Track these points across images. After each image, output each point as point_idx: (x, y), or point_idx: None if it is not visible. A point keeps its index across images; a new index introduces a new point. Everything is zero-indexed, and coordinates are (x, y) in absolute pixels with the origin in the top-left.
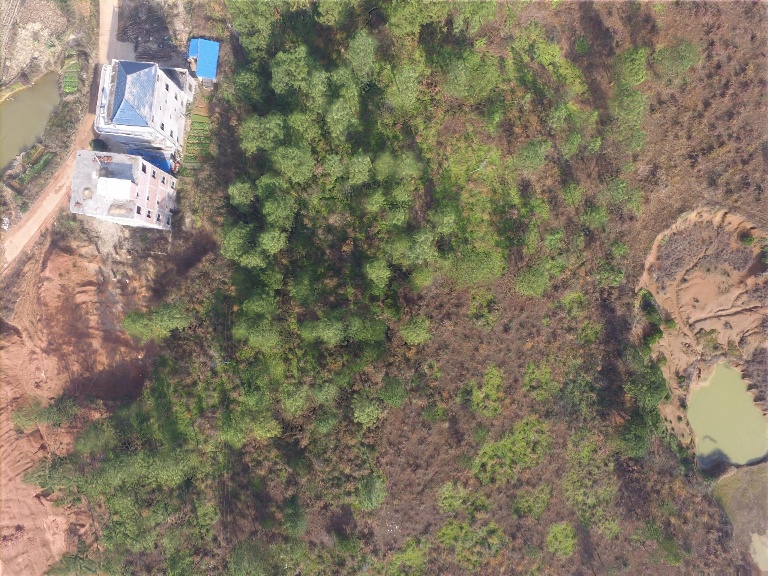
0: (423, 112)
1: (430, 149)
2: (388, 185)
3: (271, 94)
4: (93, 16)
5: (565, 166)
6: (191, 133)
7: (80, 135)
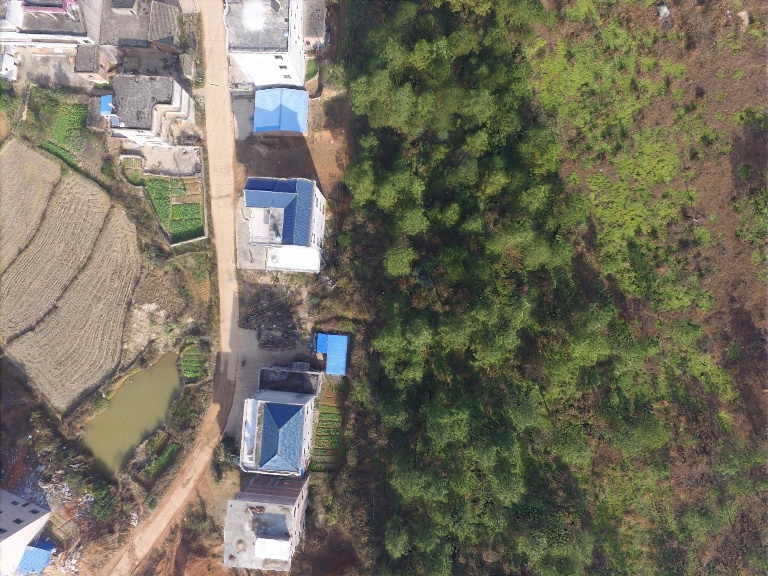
0: (577, 440)
1: (585, 479)
2: (543, 517)
3: (417, 420)
4: (214, 305)
5: (721, 483)
6: (320, 425)
7: (205, 426)
